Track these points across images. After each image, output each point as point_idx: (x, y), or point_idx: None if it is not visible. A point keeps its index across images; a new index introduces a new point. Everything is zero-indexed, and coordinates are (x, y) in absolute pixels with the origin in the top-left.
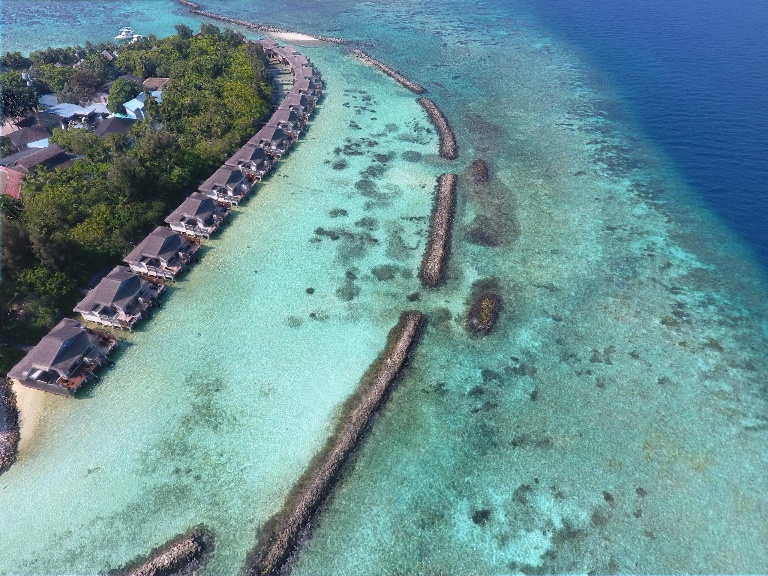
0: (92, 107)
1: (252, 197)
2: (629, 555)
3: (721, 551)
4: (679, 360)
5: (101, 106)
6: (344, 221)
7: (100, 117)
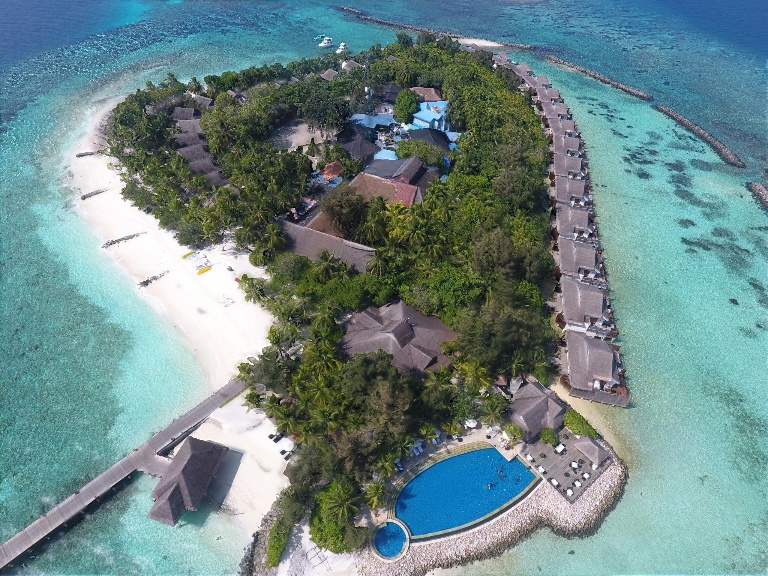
0: (380, 117)
1: None
2: None
3: None
4: None
5: (388, 116)
6: (700, 231)
7: (395, 127)
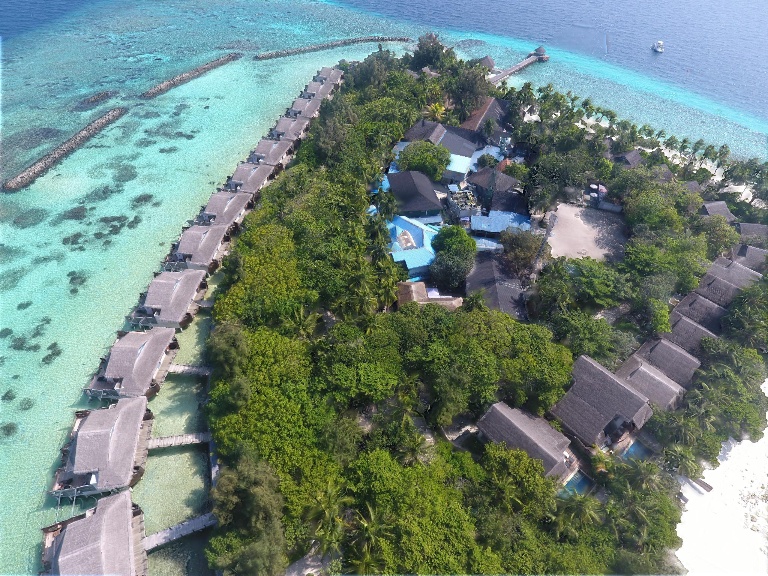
0: None
1: None
2: None
3: None
4: (4, 83)
5: None
6: (166, 144)
7: None
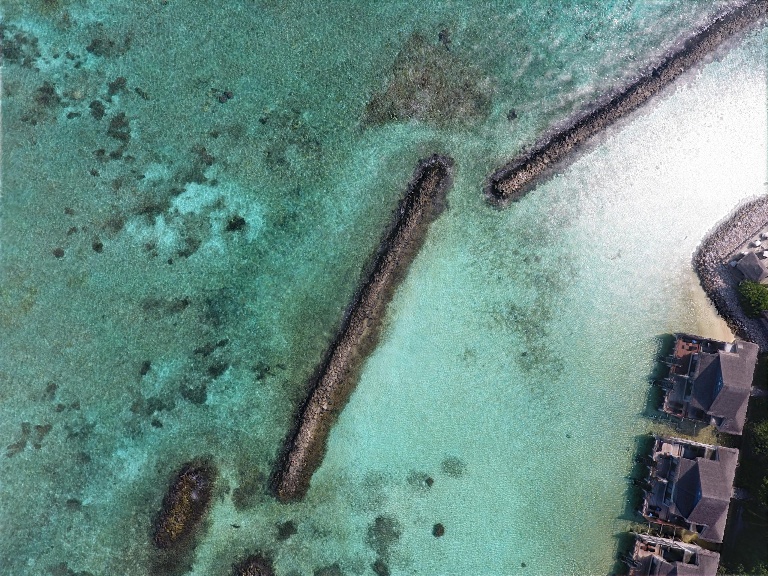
0: None
1: None
2: (98, 194)
3: (2, 199)
4: None
5: None
6: None
7: None
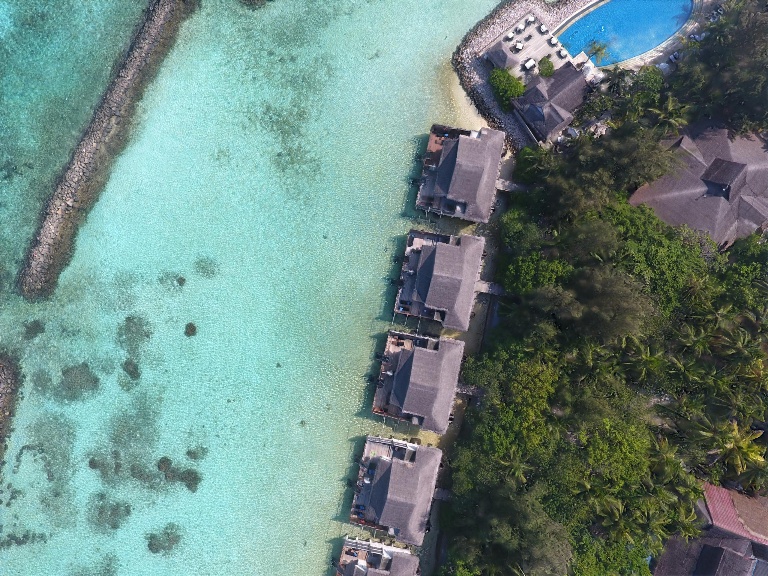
0: None
1: (329, 572)
2: None
3: None
4: None
5: None
6: (151, 516)
7: None
